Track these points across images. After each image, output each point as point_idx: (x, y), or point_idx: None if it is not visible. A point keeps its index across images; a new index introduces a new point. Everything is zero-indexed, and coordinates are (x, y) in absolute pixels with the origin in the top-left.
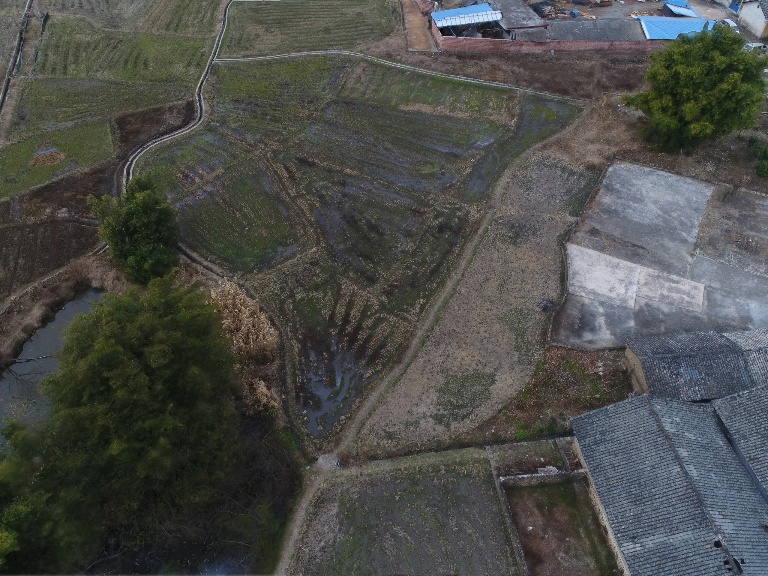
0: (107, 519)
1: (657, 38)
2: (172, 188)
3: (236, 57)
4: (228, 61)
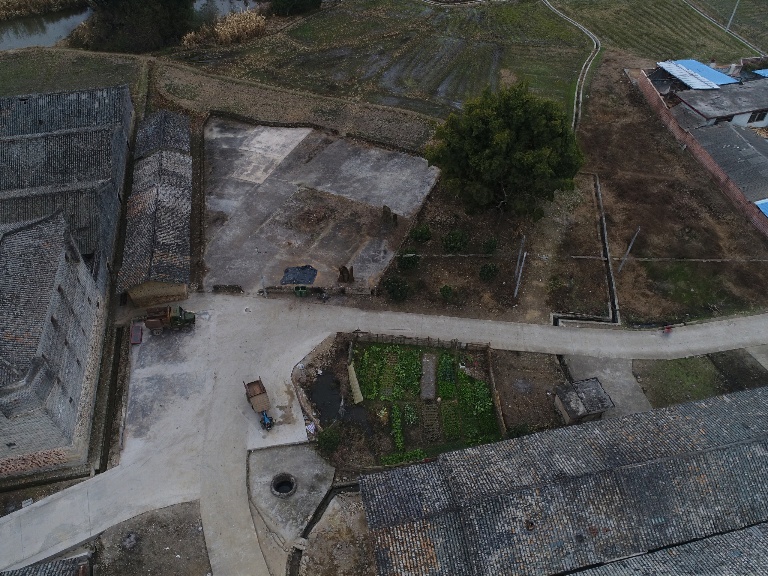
0: (126, 6)
1: (764, 211)
2: (366, 8)
3: (556, 6)
4: (545, 3)
